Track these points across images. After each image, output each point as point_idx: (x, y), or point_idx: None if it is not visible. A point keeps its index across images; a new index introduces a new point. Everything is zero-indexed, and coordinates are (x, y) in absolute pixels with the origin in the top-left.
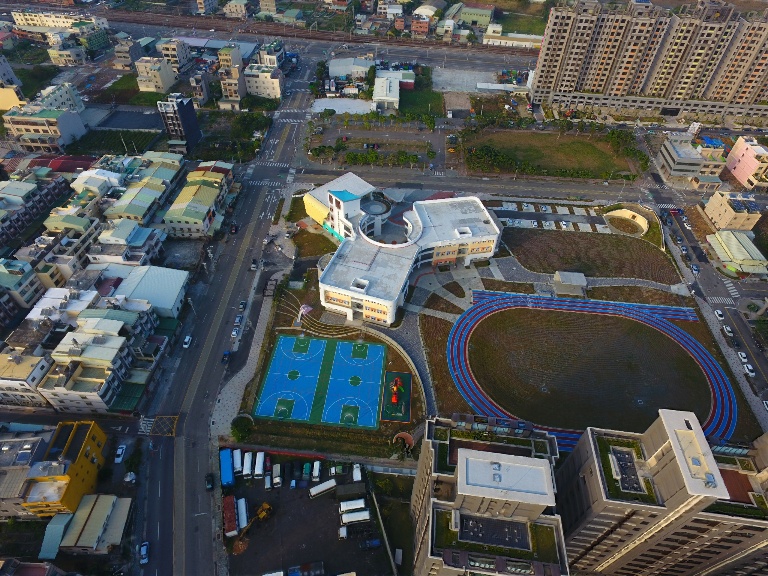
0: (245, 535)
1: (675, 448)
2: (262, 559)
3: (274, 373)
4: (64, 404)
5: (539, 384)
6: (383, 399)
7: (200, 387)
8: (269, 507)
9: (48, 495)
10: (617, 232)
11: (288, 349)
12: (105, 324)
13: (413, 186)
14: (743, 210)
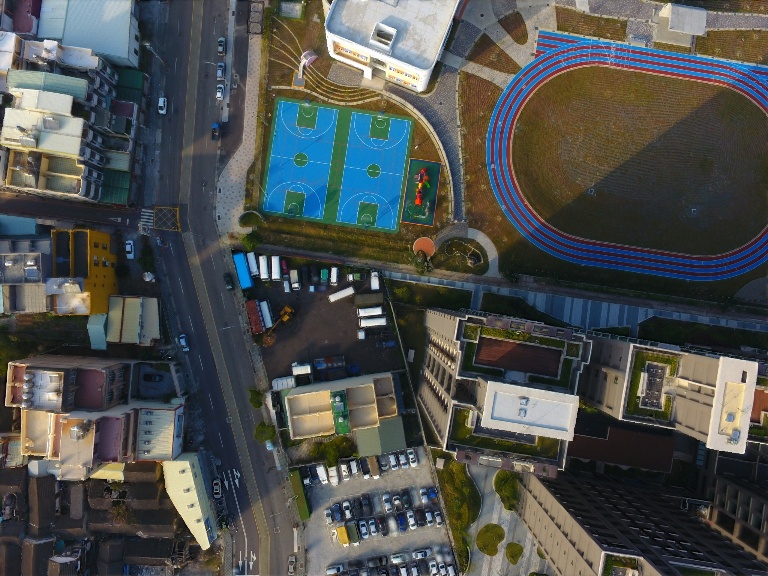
0: (272, 332)
1: (717, 403)
2: (290, 351)
3: (278, 156)
4: (46, 195)
5: (587, 184)
6: (405, 196)
7: (194, 172)
8: (291, 311)
9: (75, 306)
10: None
11: (291, 121)
12: (48, 100)
13: None
14: None
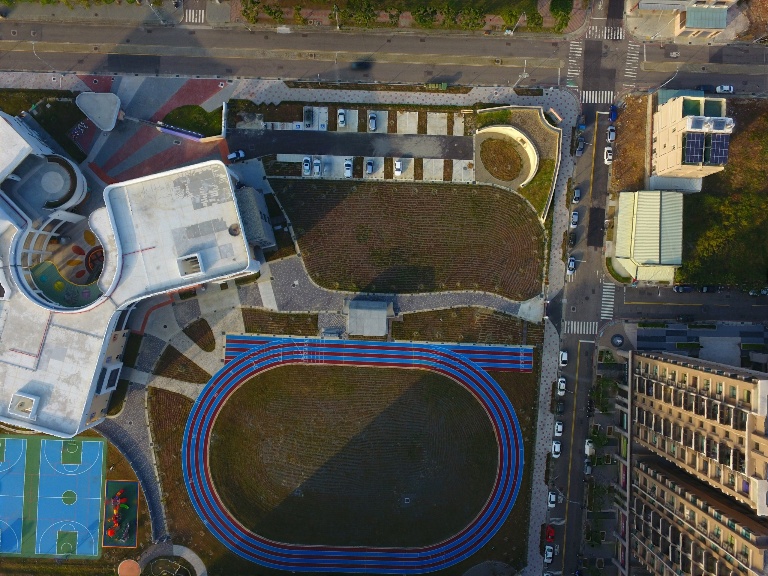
0: None
1: None
2: None
3: None
4: None
5: (293, 485)
6: (104, 520)
7: None
8: None
9: None
10: (484, 179)
11: None
12: None
13: (141, 65)
14: (697, 161)
